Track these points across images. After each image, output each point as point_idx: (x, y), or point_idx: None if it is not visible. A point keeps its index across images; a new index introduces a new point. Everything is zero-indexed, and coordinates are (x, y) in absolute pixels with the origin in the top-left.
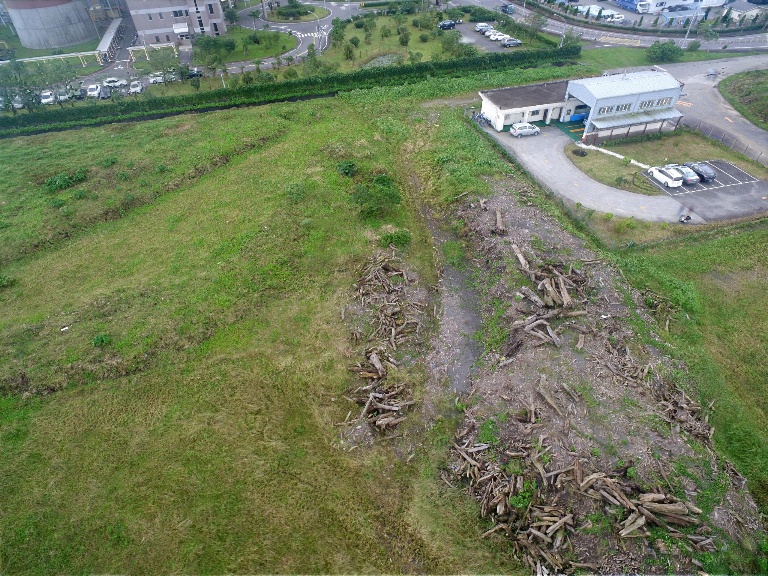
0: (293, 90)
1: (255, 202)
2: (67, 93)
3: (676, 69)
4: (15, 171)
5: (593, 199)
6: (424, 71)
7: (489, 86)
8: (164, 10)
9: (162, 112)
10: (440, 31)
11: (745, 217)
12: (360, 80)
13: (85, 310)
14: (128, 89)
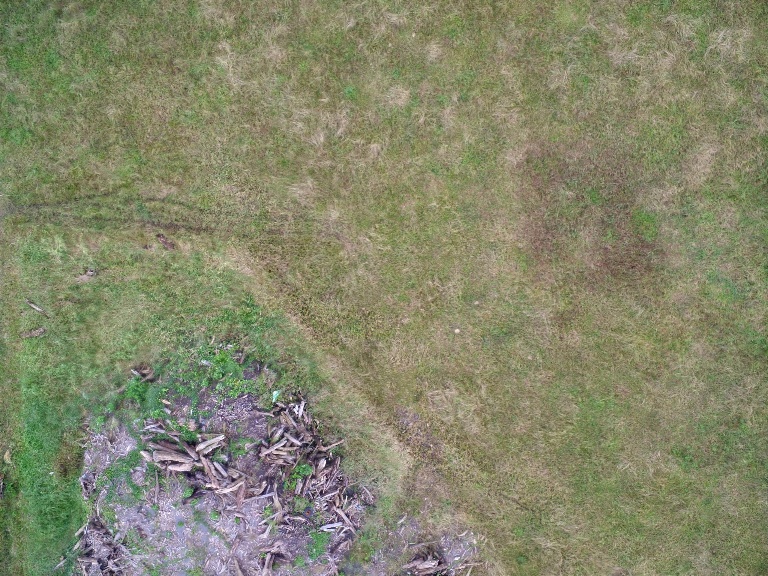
0: None
1: None
2: None
3: None
4: None
5: None
6: None
7: None
8: None
9: None
10: None
11: None
12: None
13: None
14: None
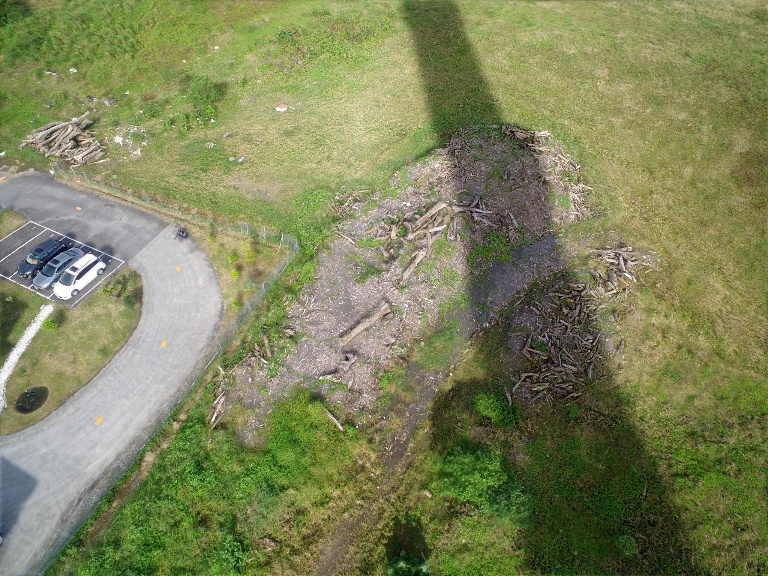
0: None
1: None
2: None
3: None
4: None
5: (194, 311)
6: None
7: None
8: None
9: None
10: None
11: (137, 208)
12: None
13: None
14: None
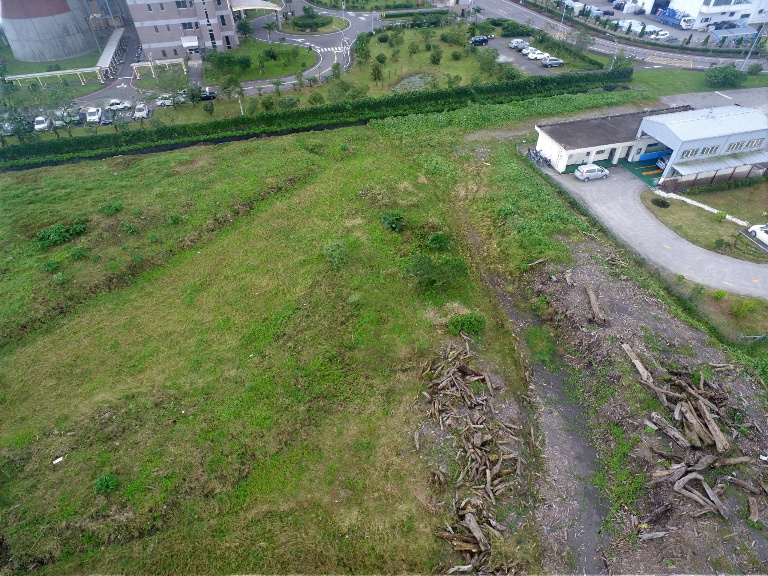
0: (319, 117)
1: (288, 266)
2: (64, 121)
3: (741, 96)
4: (1, 219)
5: (692, 268)
6: (463, 96)
7: (538, 115)
8: (172, 22)
9: (172, 142)
10: (473, 48)
11: None
12: (393, 106)
13: (84, 428)
14: (133, 113)
